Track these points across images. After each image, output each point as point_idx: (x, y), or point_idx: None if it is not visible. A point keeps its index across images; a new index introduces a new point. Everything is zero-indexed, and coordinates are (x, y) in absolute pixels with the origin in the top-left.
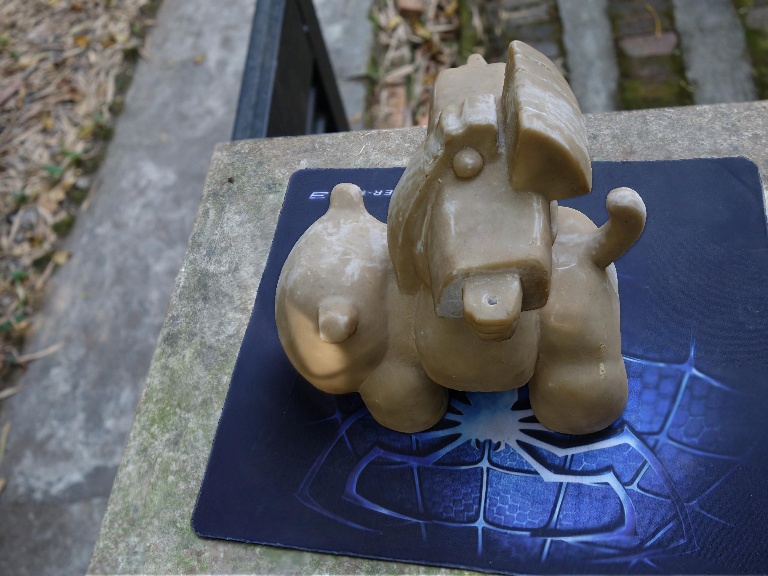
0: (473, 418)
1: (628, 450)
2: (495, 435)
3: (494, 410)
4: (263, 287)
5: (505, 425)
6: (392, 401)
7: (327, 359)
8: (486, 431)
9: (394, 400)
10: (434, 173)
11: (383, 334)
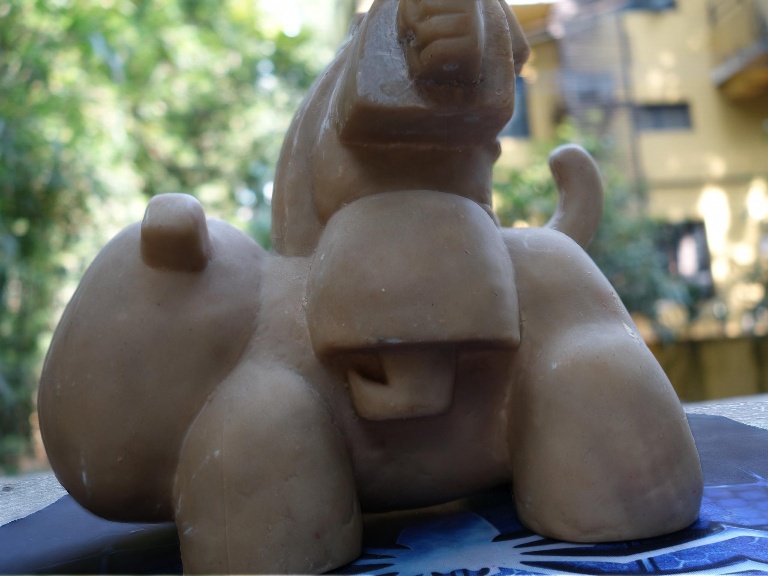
0: (418, 557)
1: (754, 539)
2: (472, 563)
3: (458, 546)
4: (9, 527)
5: (488, 553)
6: (250, 443)
7: (136, 326)
8: (451, 563)
9: (255, 438)
10: (345, 55)
11: (251, 297)
